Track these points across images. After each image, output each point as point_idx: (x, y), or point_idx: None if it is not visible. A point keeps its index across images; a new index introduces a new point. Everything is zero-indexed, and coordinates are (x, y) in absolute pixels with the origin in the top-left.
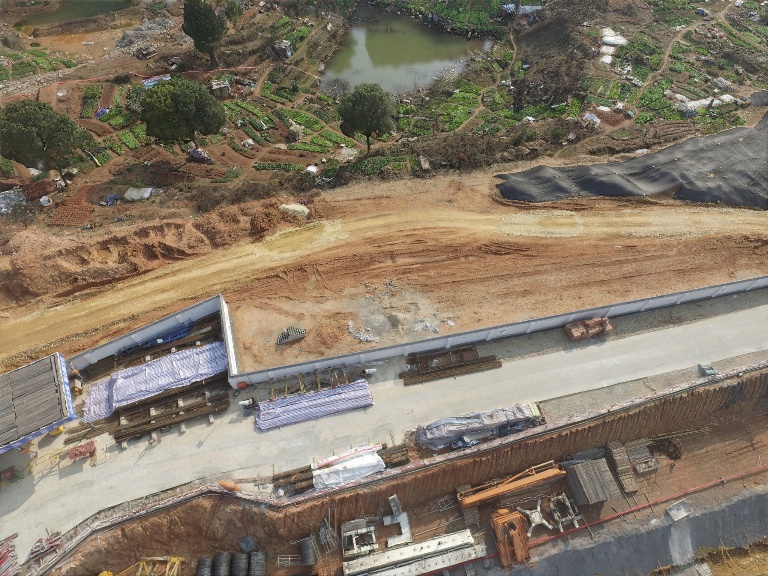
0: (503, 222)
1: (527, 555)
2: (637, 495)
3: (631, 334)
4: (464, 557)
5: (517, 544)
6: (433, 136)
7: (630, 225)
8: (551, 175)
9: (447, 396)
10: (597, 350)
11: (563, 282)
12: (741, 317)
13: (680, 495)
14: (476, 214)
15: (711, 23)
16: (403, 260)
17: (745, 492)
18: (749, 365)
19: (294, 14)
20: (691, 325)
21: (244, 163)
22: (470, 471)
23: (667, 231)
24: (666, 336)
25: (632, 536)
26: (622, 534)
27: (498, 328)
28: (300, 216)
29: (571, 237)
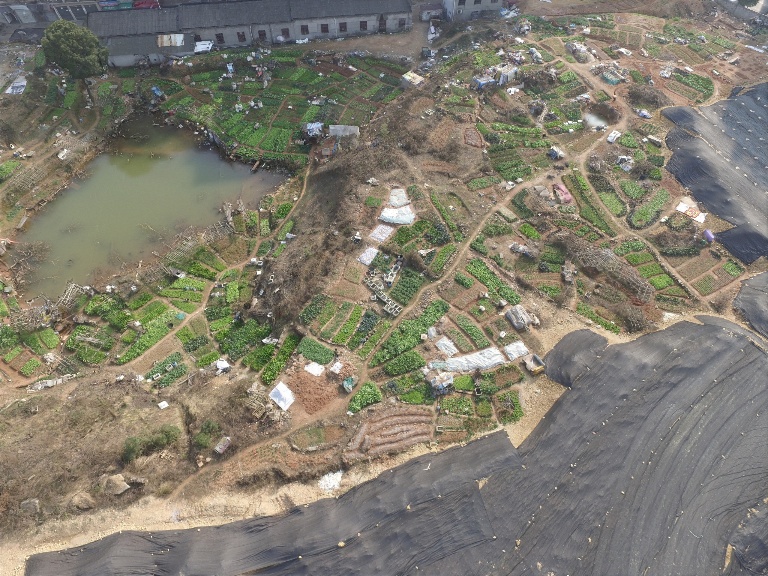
0: None
1: None
2: None
3: None
4: None
5: None
6: (93, 373)
7: None
8: None
9: None
10: None
11: None
12: None
13: None
14: None
15: (562, 174)
16: None
17: None
18: None
19: (2, 142)
20: None
21: None
22: None
23: None
24: None
25: None
26: None
27: None
28: None
29: None
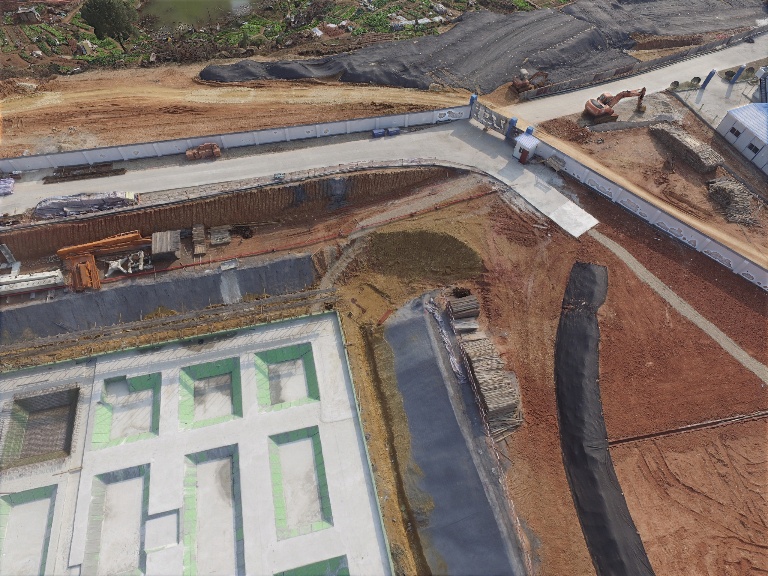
0: (191, 94)
1: (98, 285)
2: (204, 257)
3: (238, 157)
4: (45, 282)
5: (83, 273)
6: None
7: (290, 96)
8: (245, 64)
9: (72, 190)
10: (205, 166)
11: (209, 128)
12: (329, 148)
13: (236, 257)
14: (173, 89)
15: None
16: (95, 116)
17: (287, 256)
18: (307, 171)
19: None
20: (287, 152)
21: (24, 66)
22: (70, 234)
23: (318, 100)
24: (263, 158)
25: (187, 279)
26: (179, 277)
27: (124, 146)
28: (29, 89)
29: (238, 103)
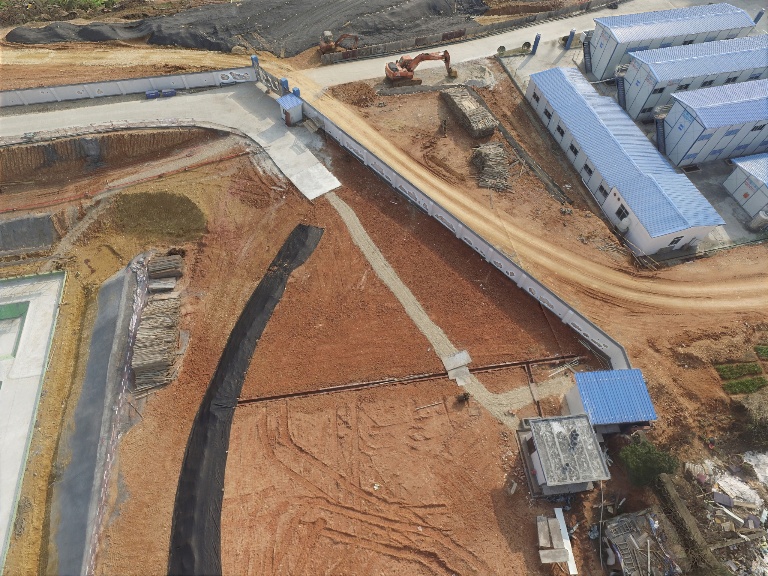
0: None
1: None
2: None
3: None
4: None
5: None
6: None
7: (88, 58)
8: (55, 26)
9: None
10: None
11: None
12: (96, 108)
13: None
14: None
15: None
16: None
17: (25, 216)
18: (56, 130)
19: None
20: (52, 112)
21: None
22: None
23: (114, 62)
24: (24, 118)
25: None
26: None
27: None
28: None
29: (32, 65)
